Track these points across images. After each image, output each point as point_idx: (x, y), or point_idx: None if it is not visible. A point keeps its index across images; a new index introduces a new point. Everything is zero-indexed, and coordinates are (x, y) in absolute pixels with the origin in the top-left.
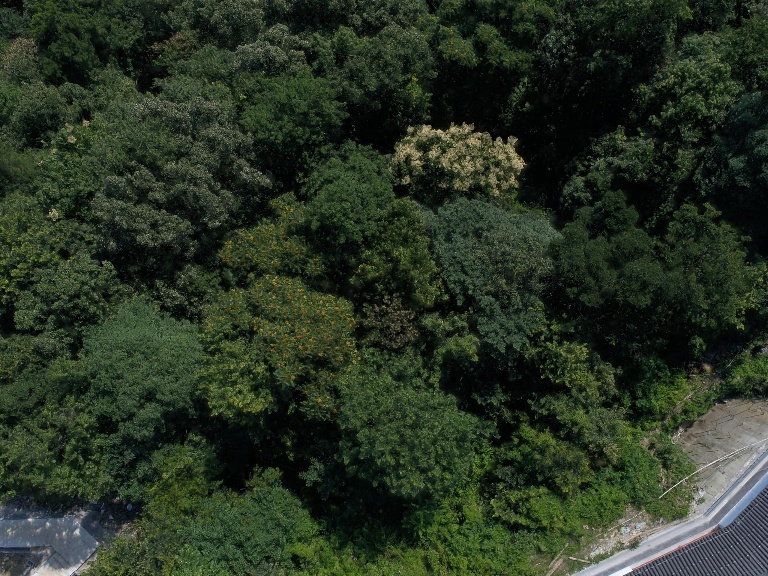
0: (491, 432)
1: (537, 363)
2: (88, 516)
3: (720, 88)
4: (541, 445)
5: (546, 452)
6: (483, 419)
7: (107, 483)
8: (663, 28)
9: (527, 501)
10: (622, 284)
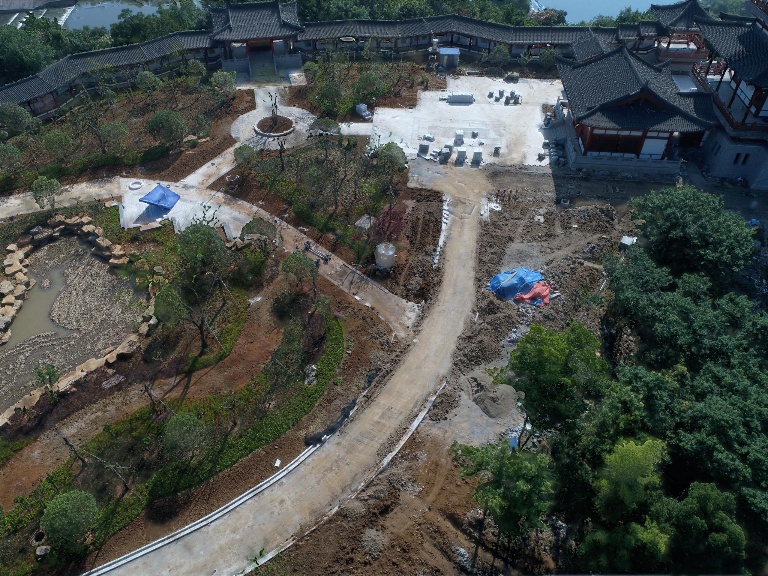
0: None
1: None
2: None
3: None
4: None
5: None
6: None
7: None
8: None
9: None
10: None
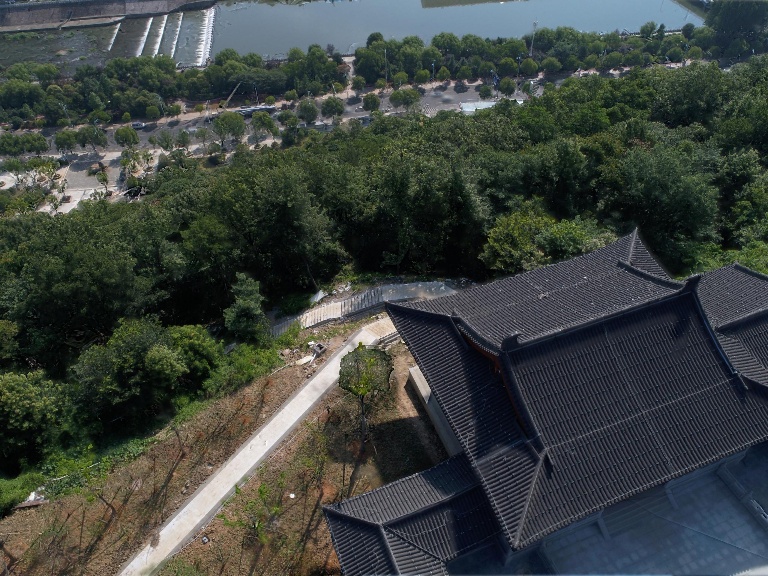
0: (716, 236)
1: (730, 178)
2: (448, 282)
3: (759, 97)
4: (757, 194)
5: (763, 195)
6: (707, 227)
7: (486, 214)
8: (715, 91)
9: (766, 222)
10: (761, 111)
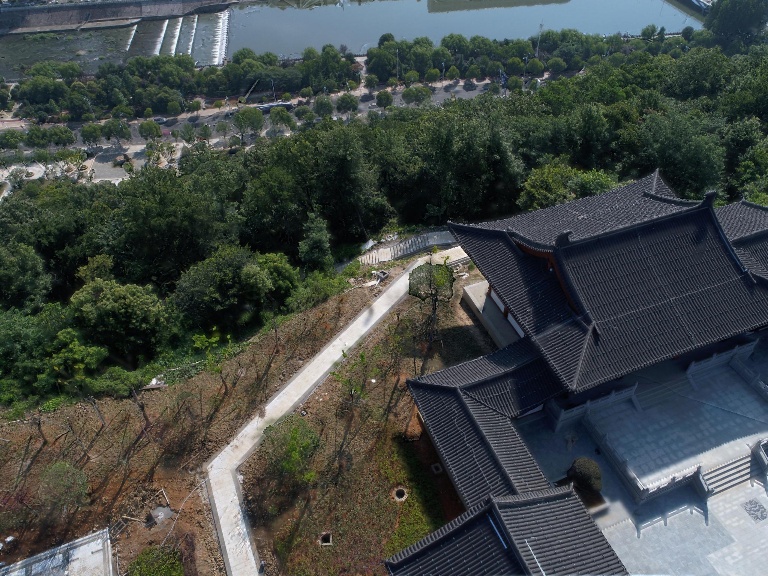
0: (722, 194)
1: (734, 143)
2: None
3: None
4: (759, 154)
5: (764, 155)
6: None
7: (520, 169)
8: (718, 73)
9: (767, 177)
10: (762, 84)
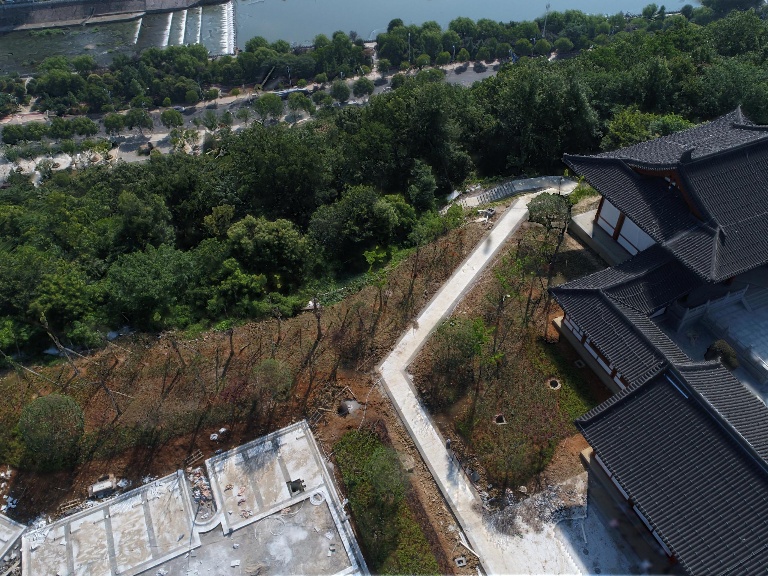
0: None
1: None
2: None
3: None
4: None
5: None
6: None
7: None
8: (753, 34)
9: None
10: None
